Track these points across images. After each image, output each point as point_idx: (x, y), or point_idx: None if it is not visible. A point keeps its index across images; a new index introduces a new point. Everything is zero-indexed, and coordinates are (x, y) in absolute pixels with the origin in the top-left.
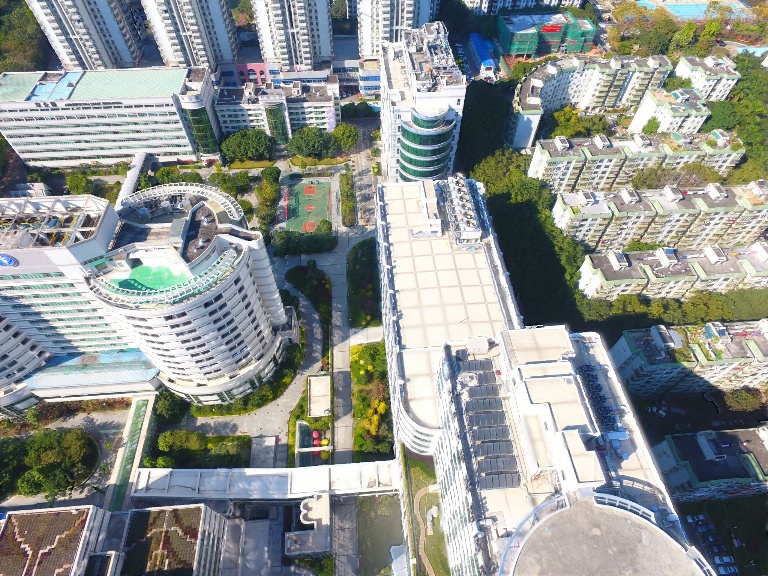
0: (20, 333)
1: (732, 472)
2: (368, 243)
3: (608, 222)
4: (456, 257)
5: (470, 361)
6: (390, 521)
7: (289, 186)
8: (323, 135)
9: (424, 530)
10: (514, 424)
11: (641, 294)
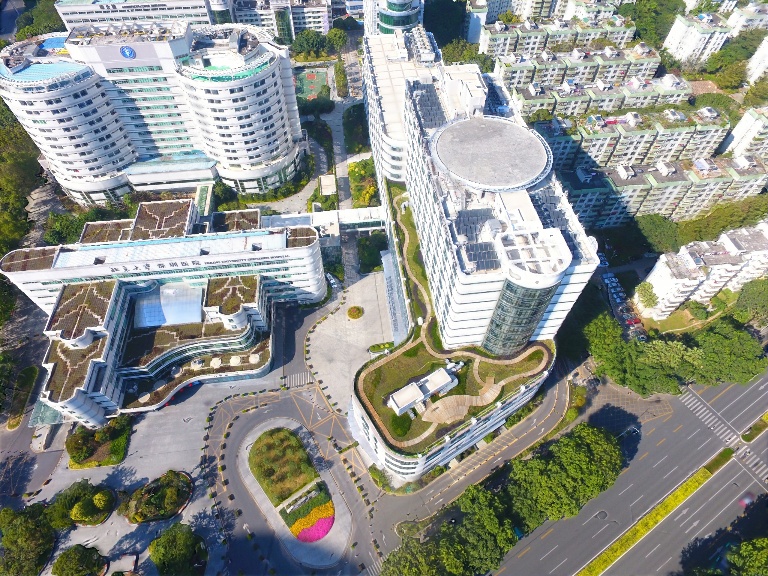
0: (123, 129)
1: (597, 187)
2: (358, 106)
3: (532, 74)
4: (418, 71)
5: (421, 84)
6: (379, 242)
7: (295, 74)
8: (320, 36)
9: (400, 212)
10: (445, 106)
11: (553, 115)
